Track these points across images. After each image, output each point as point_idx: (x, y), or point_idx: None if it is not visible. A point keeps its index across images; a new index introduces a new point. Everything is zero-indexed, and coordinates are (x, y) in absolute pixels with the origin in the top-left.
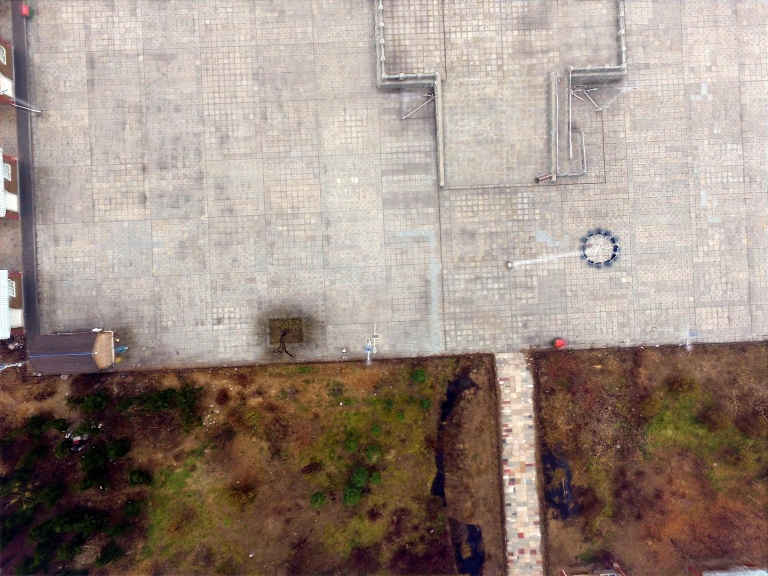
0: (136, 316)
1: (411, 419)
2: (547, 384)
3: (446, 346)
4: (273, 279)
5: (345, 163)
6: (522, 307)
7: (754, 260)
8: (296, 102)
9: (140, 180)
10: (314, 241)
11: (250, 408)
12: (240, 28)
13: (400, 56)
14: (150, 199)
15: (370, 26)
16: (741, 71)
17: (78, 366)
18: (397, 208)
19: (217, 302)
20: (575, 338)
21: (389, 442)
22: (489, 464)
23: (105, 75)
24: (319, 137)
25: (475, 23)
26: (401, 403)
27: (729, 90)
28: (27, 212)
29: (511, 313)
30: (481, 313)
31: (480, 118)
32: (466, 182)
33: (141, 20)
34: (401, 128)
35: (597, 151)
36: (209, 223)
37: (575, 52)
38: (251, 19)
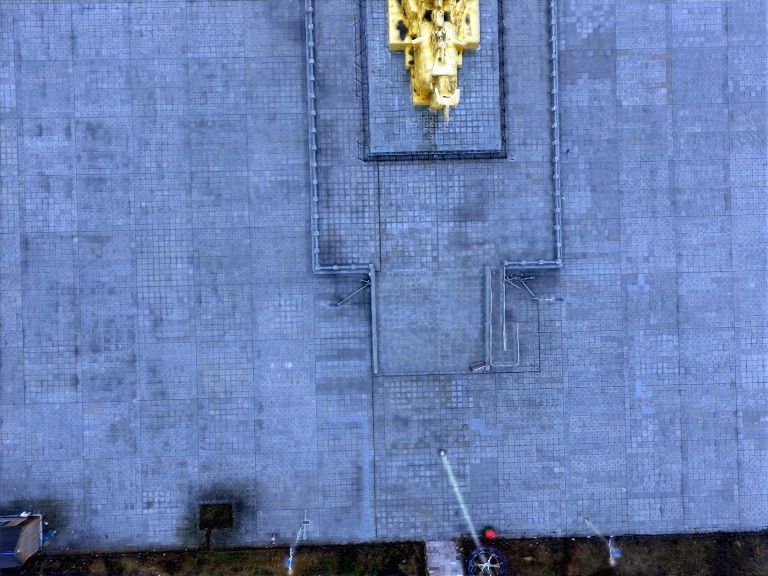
0: (65, 499)
1: None
2: None
3: (377, 533)
4: (204, 463)
5: (279, 348)
6: (454, 495)
7: (688, 452)
8: (231, 286)
9: (72, 362)
10: (246, 426)
11: None
12: (176, 211)
13: (335, 246)
14: (82, 381)
15: (307, 211)
16: (678, 262)
17: (0, 563)
18: (330, 394)
19: (147, 486)
20: (506, 527)
21: None
22: None
23: (39, 257)
24: (253, 321)
25: (411, 214)
26: None
27: (666, 281)
28: None
29: (443, 501)
30: (412, 501)
31: (415, 307)
32: (400, 369)
33: (76, 202)
34: (336, 314)
35: (532, 340)
36: (141, 406)
37: (511, 245)
38: (187, 202)
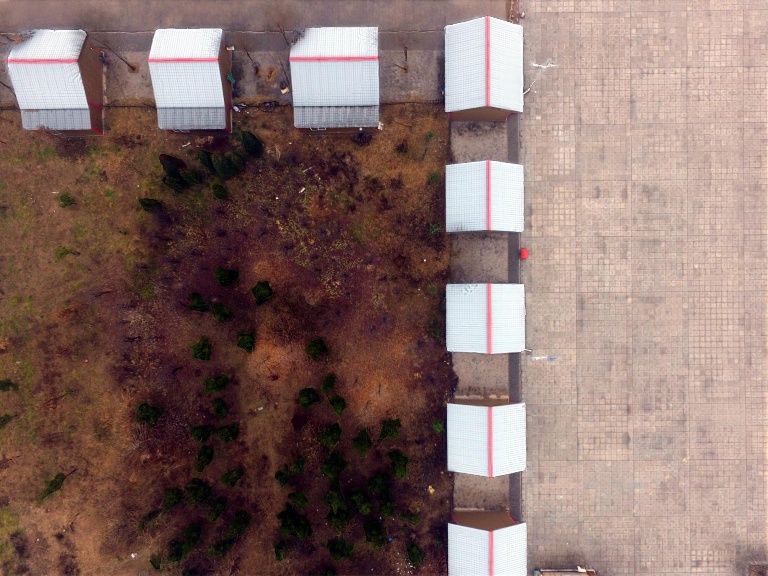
0: (616, 555)
1: None
2: None
3: None
4: (752, 524)
5: None
6: None
7: None
8: None
9: (624, 420)
10: None
11: None
12: (728, 273)
13: None
14: (633, 439)
15: None
16: None
17: None
18: None
19: (696, 544)
20: None
21: None
22: None
23: (594, 316)
24: None
25: None
26: None
27: None
28: None
29: None
30: None
31: None
32: None
33: (631, 263)
34: None
35: None
36: (690, 465)
37: None
38: (739, 264)
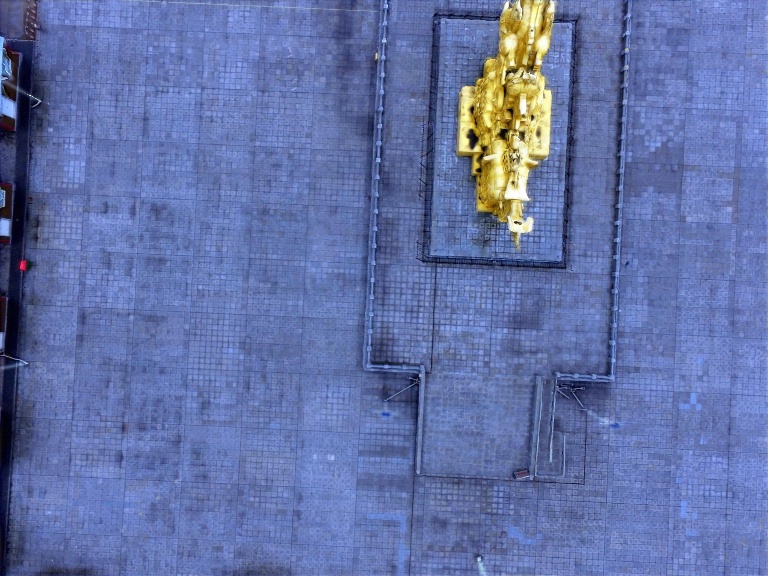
0: (101, 574)
1: None
2: None
3: None
4: (240, 550)
5: (323, 439)
6: None
7: None
8: (280, 374)
9: (118, 438)
10: (285, 515)
11: None
12: (232, 296)
13: (387, 344)
14: (126, 458)
15: (361, 305)
16: (733, 384)
17: None
18: (371, 490)
19: (182, 568)
20: None
21: None
22: None
23: (95, 331)
24: (300, 411)
25: (465, 317)
26: None
27: (719, 402)
28: (5, 461)
29: None
30: None
31: (462, 411)
32: (443, 470)
33: (135, 280)
34: (382, 409)
35: (578, 451)
36: (182, 487)
37: (564, 356)
38: (243, 288)
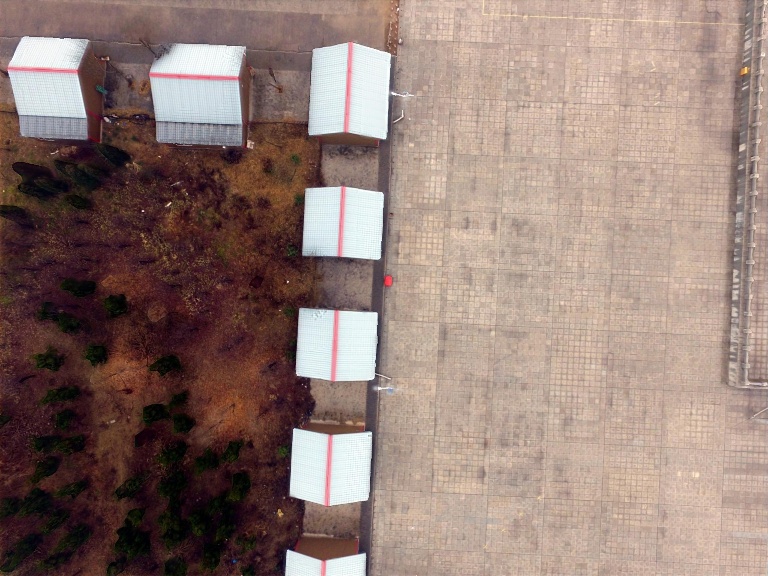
0: None
1: None
2: None
3: None
4: (604, 567)
5: (687, 457)
6: None
7: None
8: (643, 391)
9: (481, 454)
10: (649, 532)
11: None
12: (594, 312)
13: (761, 361)
14: (489, 474)
15: (725, 321)
16: None
17: None
18: (736, 508)
19: None
20: None
21: None
22: None
23: (456, 347)
24: (663, 428)
25: None
26: None
27: None
28: None
29: None
30: None
31: None
32: None
33: (496, 296)
34: (748, 427)
35: None
36: (545, 504)
37: None
38: (606, 304)
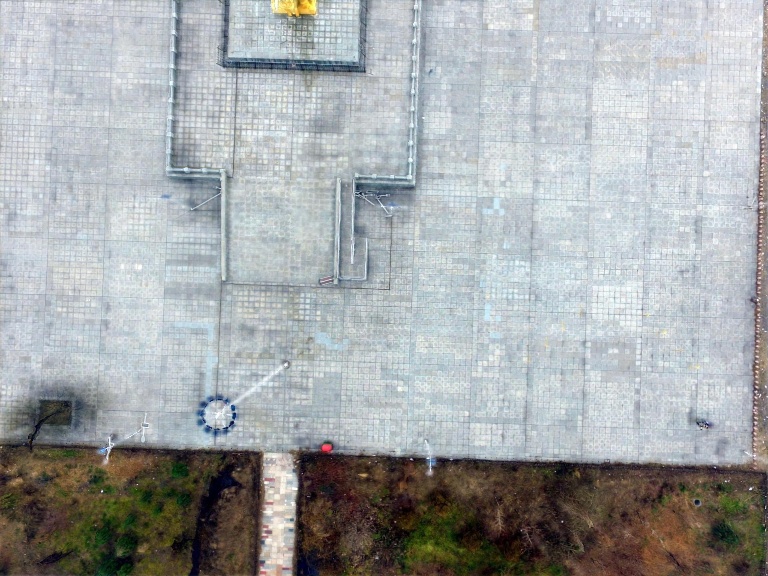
0: None
1: (171, 512)
2: (308, 489)
3: (215, 441)
4: (48, 359)
5: (130, 249)
6: (295, 408)
7: (533, 379)
8: (87, 185)
9: None
10: (92, 325)
11: (10, 488)
12: (37, 107)
13: (189, 149)
14: None
15: None
16: (535, 188)
17: None
18: (178, 298)
19: None
20: (346, 443)
21: (147, 534)
22: (245, 564)
23: None
24: (107, 221)
25: (267, 122)
26: (162, 495)
27: (522, 206)
28: None
29: (284, 413)
30: (253, 410)
31: (266, 216)
32: (250, 278)
33: None
34: (189, 219)
35: (384, 257)
36: None
37: (364, 159)
38: (49, 99)
